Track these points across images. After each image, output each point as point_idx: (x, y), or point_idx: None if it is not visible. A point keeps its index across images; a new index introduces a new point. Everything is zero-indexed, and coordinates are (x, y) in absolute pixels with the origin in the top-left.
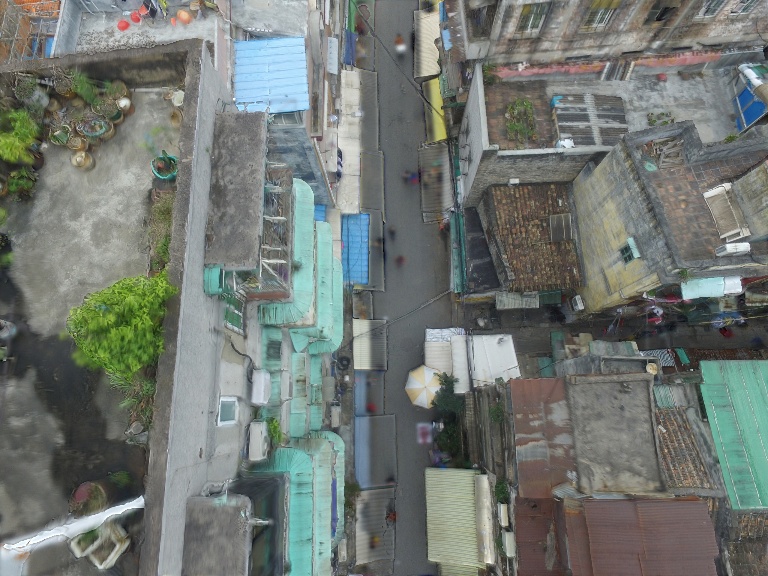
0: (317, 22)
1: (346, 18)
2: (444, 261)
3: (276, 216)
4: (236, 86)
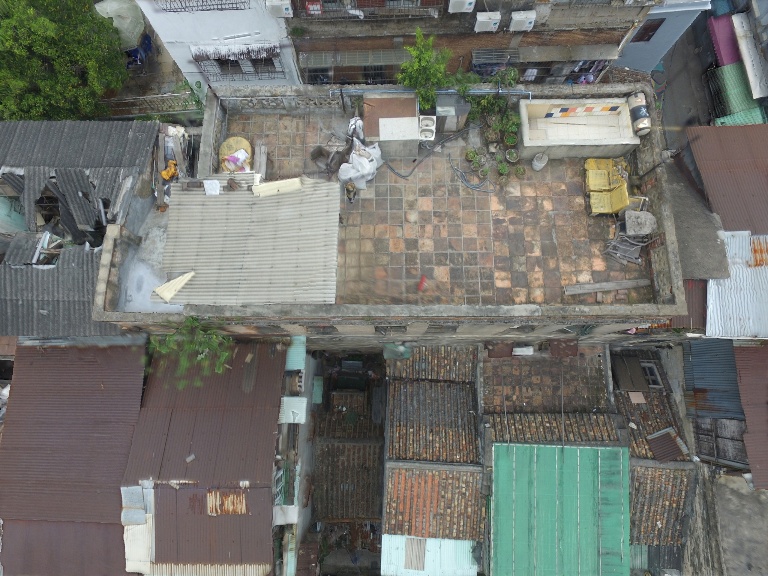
0: None
1: None
2: None
3: None
4: None
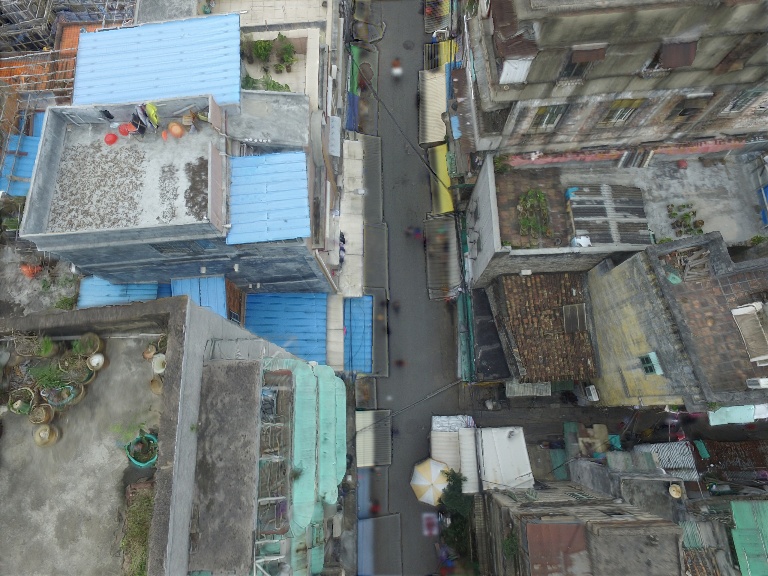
0: (319, 126)
1: (348, 79)
2: (450, 335)
3: (273, 496)
4: (232, 209)
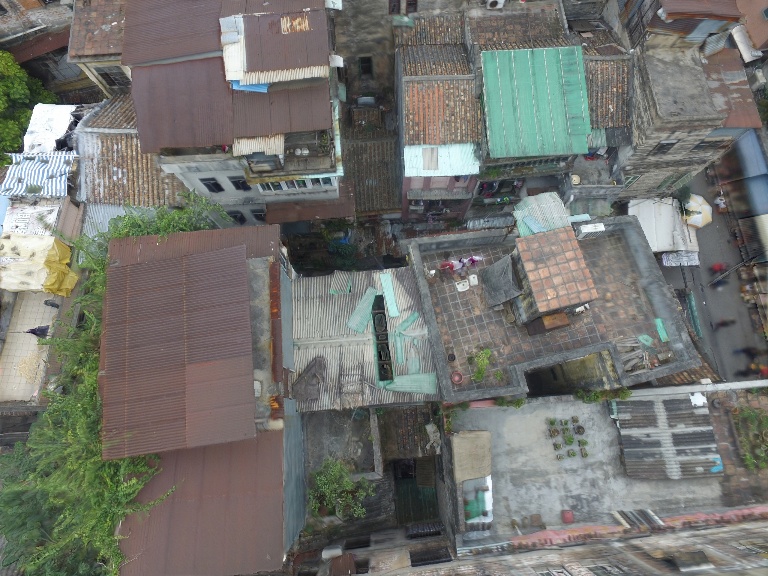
0: None
1: None
2: None
3: None
4: None
